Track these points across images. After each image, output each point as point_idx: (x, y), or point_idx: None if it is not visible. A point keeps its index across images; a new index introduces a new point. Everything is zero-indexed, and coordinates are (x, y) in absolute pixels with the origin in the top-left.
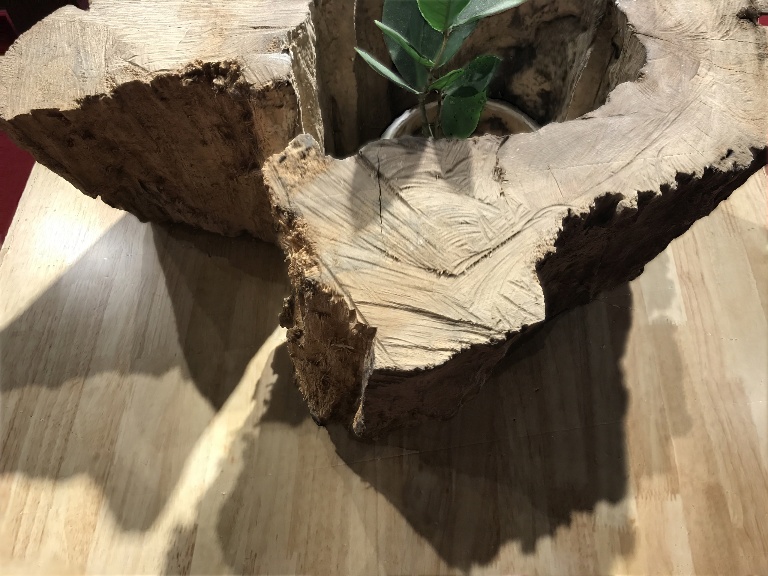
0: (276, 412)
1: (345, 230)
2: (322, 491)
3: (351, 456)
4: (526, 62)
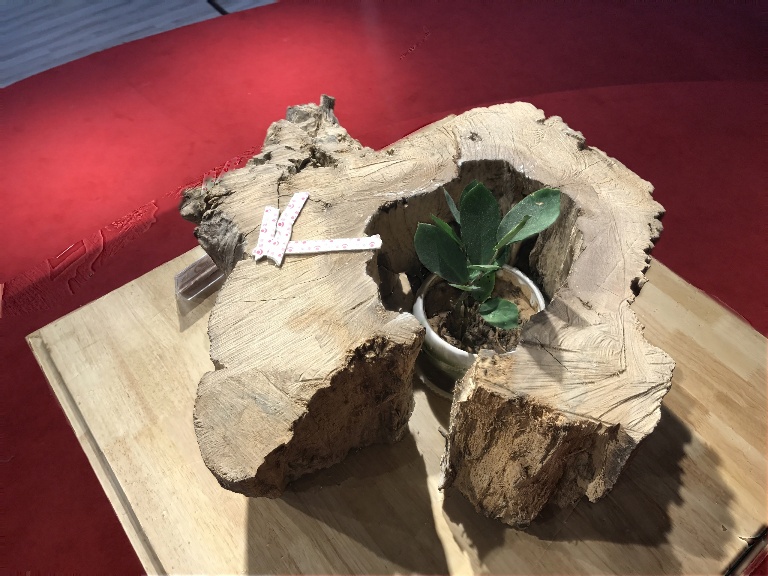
0: (484, 547)
1: (555, 386)
2: (556, 569)
3: (550, 534)
4: None
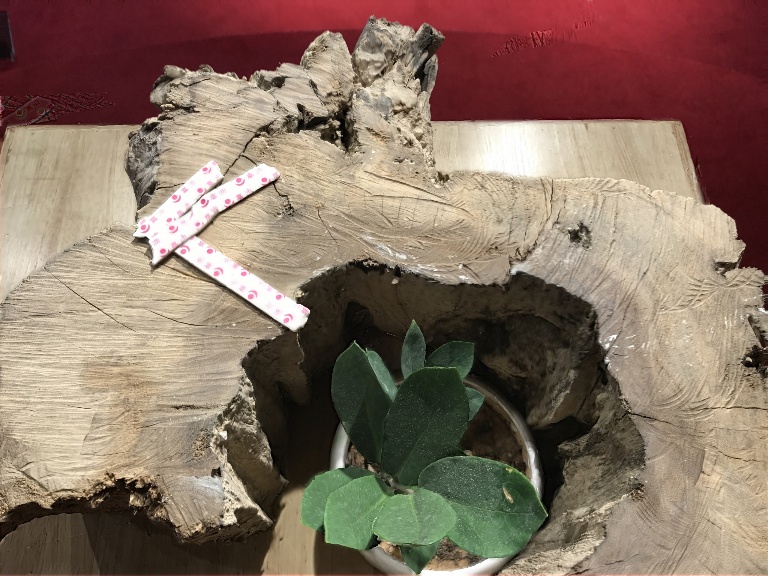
0: None
1: None
2: None
3: None
4: (498, 346)
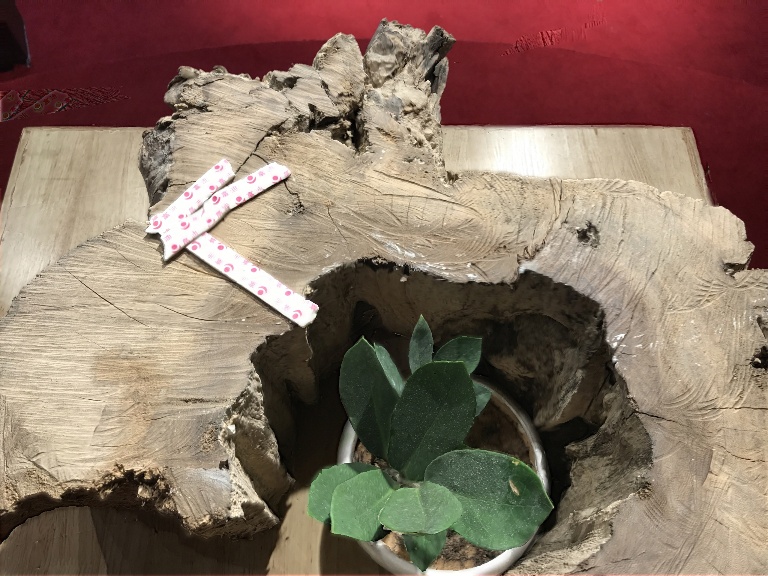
0: None
1: None
2: None
3: None
4: (506, 346)
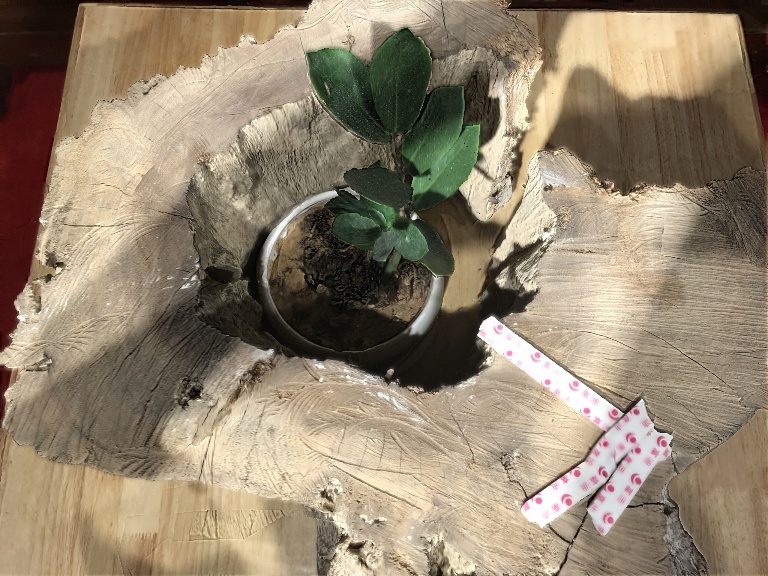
0: None
1: (468, 1)
2: None
3: None
4: None
